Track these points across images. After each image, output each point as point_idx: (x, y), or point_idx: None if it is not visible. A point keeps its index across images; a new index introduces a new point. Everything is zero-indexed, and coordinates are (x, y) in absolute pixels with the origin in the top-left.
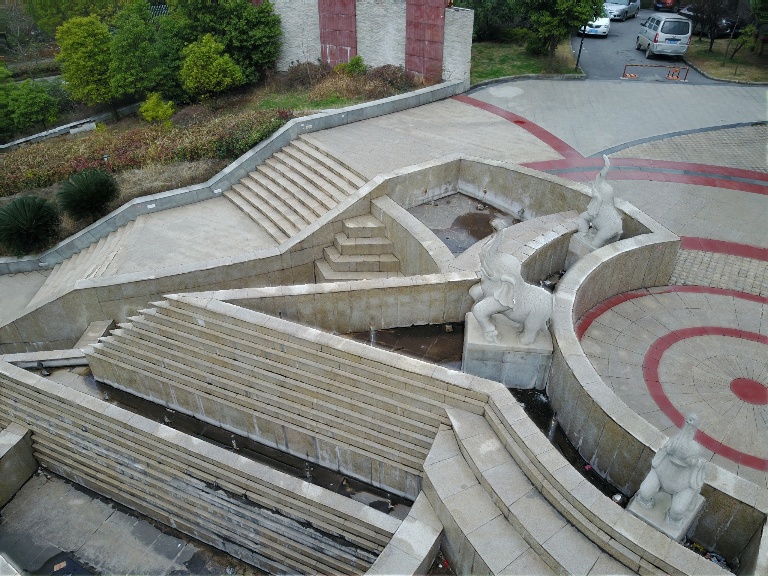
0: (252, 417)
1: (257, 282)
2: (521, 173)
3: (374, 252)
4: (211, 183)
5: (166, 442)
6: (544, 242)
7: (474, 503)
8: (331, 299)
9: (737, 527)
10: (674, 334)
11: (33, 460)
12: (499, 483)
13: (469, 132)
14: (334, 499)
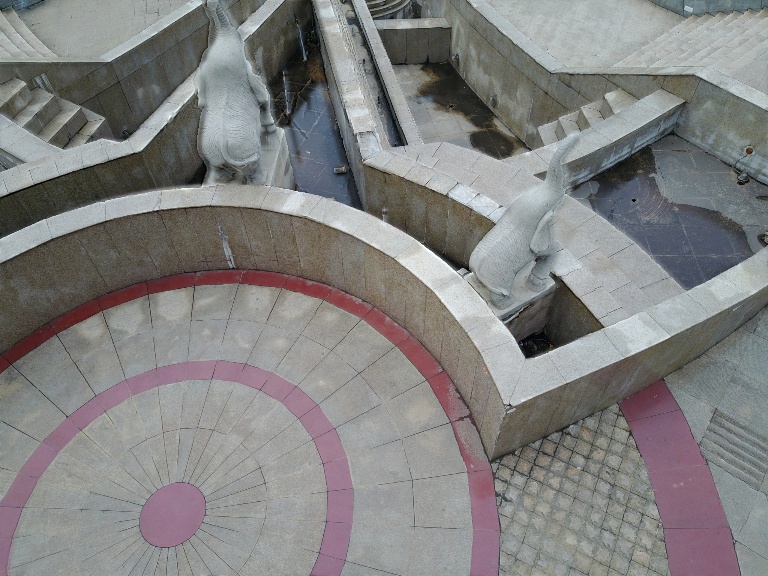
0: None
1: (526, 86)
2: None
3: None
4: None
5: None
6: (474, 205)
7: None
8: None
9: None
10: (327, 430)
11: None
12: None
13: None
14: None
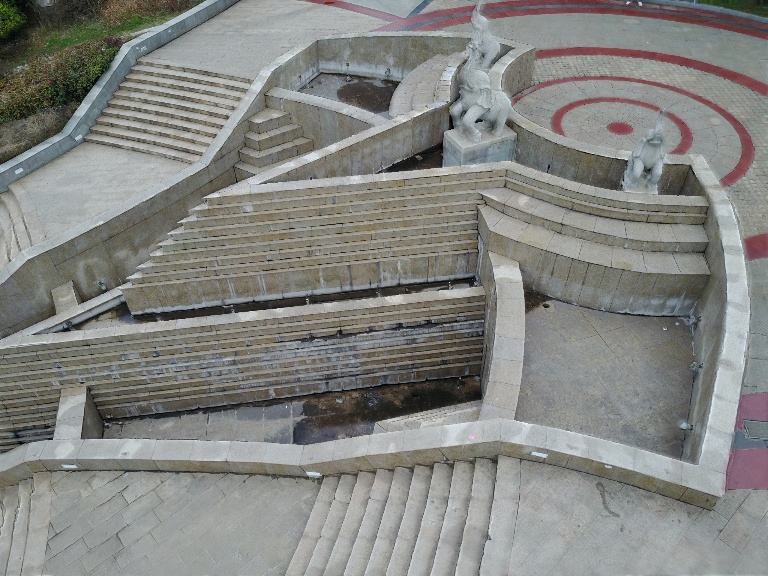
0: (318, 272)
1: (193, 200)
2: (381, 37)
3: (287, 140)
4: (69, 131)
5: (252, 323)
6: (451, 75)
7: (536, 234)
8: (337, 158)
9: (674, 183)
10: (558, 113)
11: (98, 415)
12: (546, 214)
13: (295, 20)
14: (415, 297)
